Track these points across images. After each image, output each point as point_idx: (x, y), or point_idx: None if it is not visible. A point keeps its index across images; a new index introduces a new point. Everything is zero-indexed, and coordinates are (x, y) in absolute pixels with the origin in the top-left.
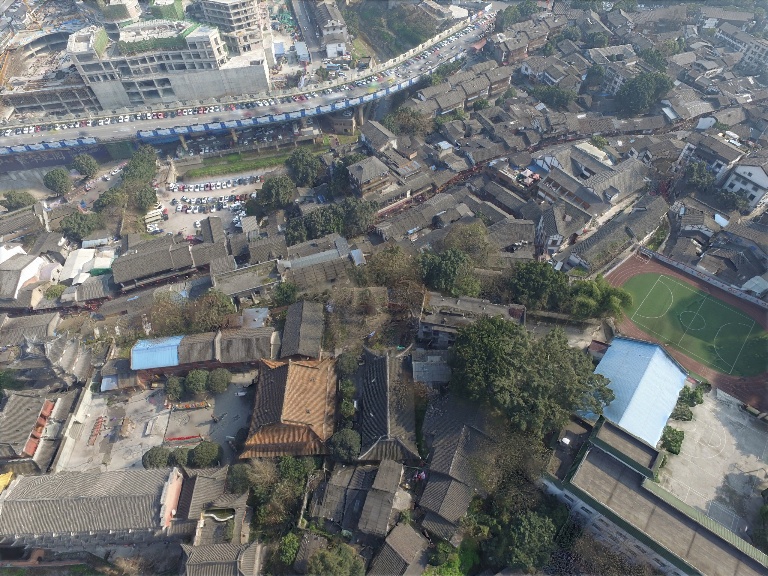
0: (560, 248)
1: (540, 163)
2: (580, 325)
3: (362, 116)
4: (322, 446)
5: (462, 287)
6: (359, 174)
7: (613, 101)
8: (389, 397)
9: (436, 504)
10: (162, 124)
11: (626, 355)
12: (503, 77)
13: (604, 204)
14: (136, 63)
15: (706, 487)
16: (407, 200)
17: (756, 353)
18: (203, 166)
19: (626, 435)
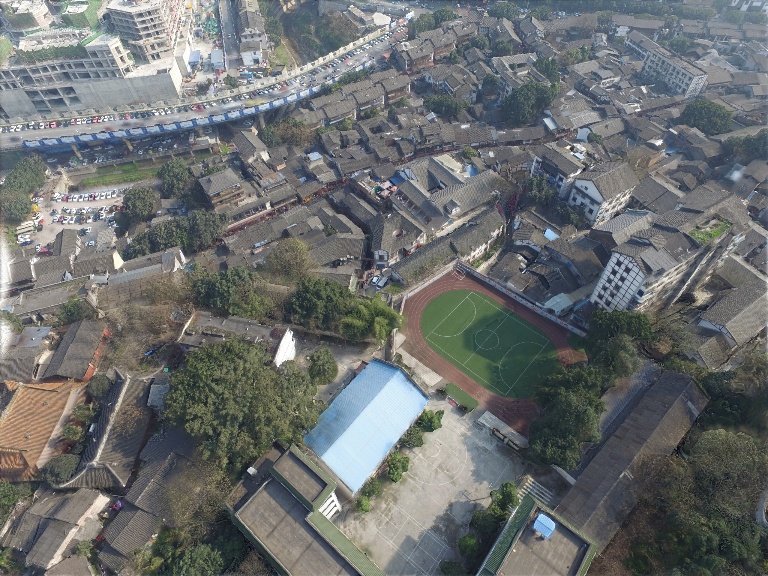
0: (389, 263)
1: (402, 175)
2: (360, 345)
3: (264, 125)
4: (38, 472)
5: (242, 306)
6: (207, 187)
7: (499, 111)
8: (113, 422)
9: (113, 535)
10: (53, 133)
11: (370, 378)
12: (400, 86)
13: (444, 218)
14: (37, 72)
15: (426, 516)
16: (268, 212)
17: (539, 374)
18: (97, 175)
19: (305, 465)
